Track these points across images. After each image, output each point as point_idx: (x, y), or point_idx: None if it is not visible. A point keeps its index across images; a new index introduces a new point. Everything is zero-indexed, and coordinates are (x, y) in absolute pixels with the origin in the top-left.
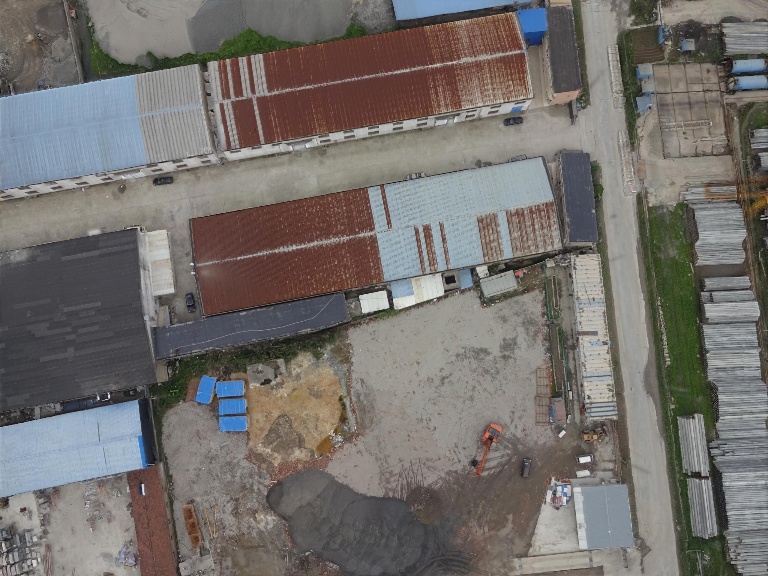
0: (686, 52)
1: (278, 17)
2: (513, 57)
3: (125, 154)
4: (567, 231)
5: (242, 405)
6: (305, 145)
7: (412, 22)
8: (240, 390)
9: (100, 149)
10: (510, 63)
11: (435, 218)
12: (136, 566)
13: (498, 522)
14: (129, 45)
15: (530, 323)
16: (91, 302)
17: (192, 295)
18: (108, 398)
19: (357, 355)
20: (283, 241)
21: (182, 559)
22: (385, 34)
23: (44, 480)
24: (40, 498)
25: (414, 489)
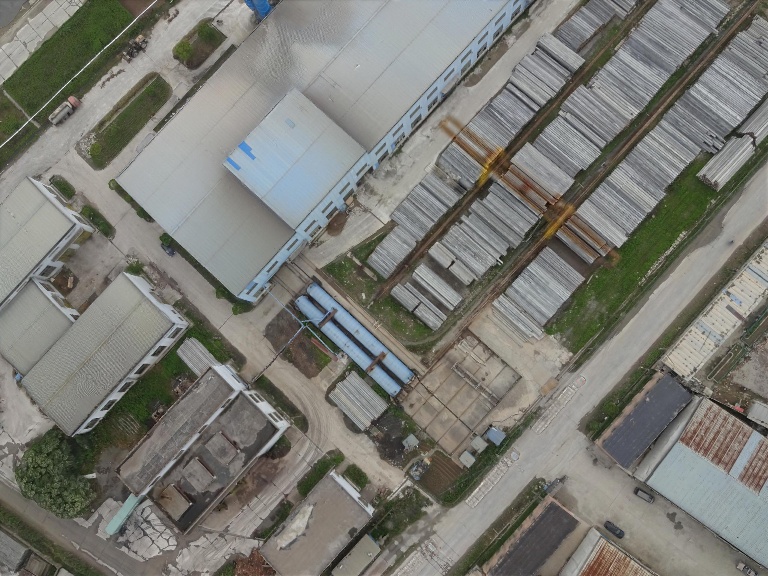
0: None
1: None
2: None
3: None
4: None
5: None
6: None
7: None
8: None
9: None
10: None
11: None
12: None
13: None
14: None
15: (766, 363)
16: None
17: None
18: None
19: None
20: None
21: None
22: None
23: None
24: None
25: None
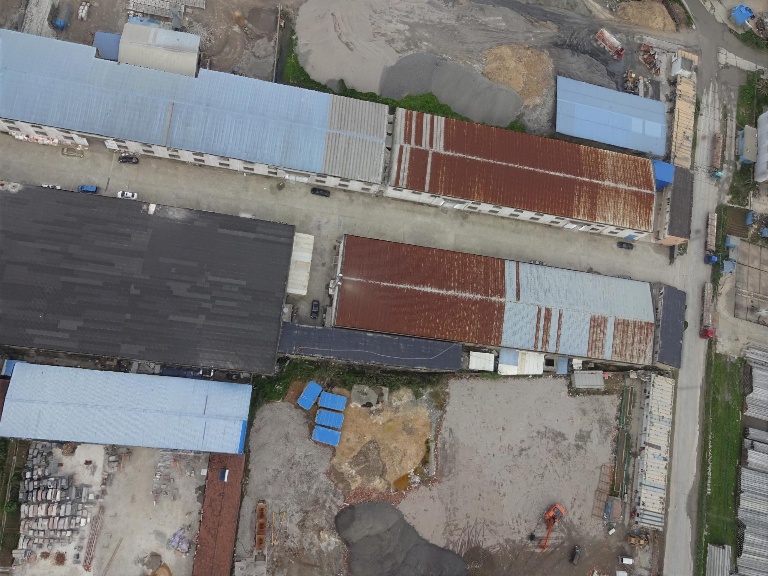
0: (765, 238)
1: (460, 92)
2: (645, 195)
3: (304, 158)
4: (658, 352)
5: (339, 420)
6: (455, 205)
7: (565, 137)
8: (342, 405)
9: (283, 145)
10: (642, 198)
11: (557, 305)
12: (188, 553)
13: None
14: (327, 67)
15: (605, 422)
16: (237, 279)
17: (319, 303)
18: (211, 375)
19: (452, 405)
20: (424, 281)
21: (236, 558)
22: (548, 139)
23: (135, 437)
24: (111, 455)
25: (473, 548)
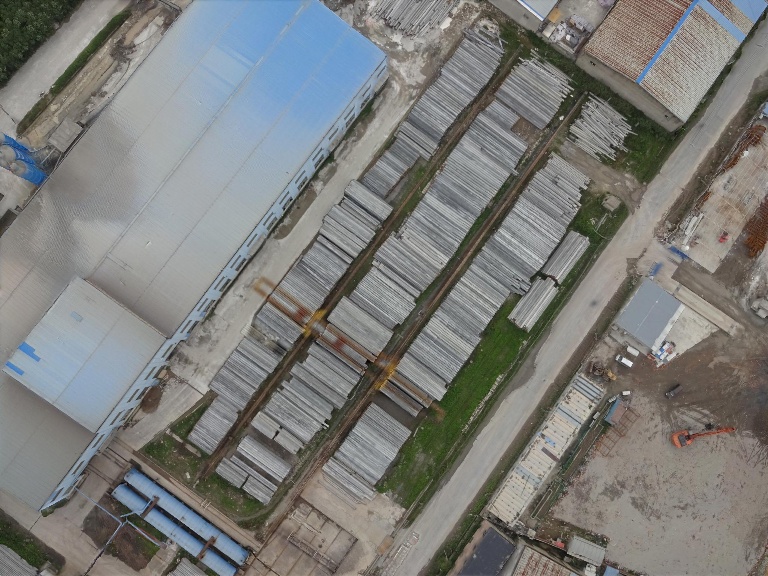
0: None
1: None
2: None
3: None
4: None
5: None
6: None
7: None
8: None
9: None
10: None
11: None
12: None
13: (723, 370)
14: None
15: (582, 496)
16: None
17: None
18: None
19: None
20: None
21: None
22: None
23: None
24: None
25: (767, 445)
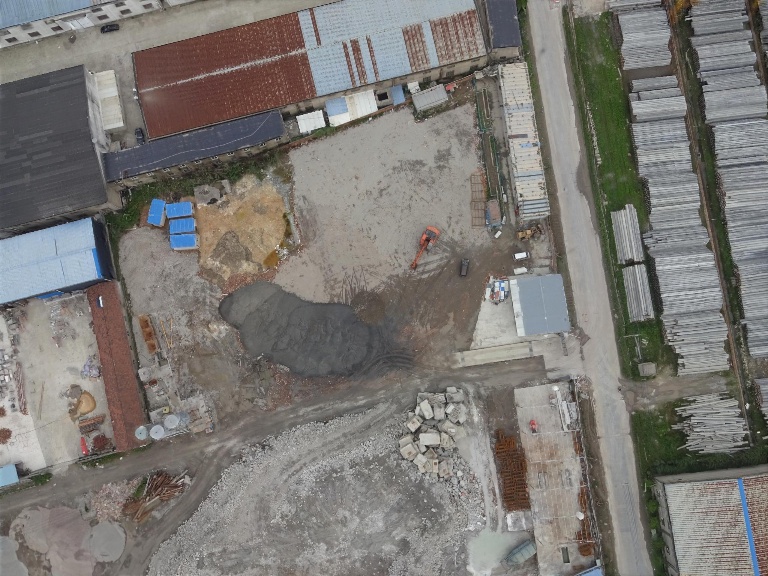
0: None
1: None
2: None
3: None
4: (491, 38)
5: (191, 224)
6: None
7: None
8: (188, 210)
9: None
10: None
11: (362, 33)
12: (100, 377)
13: (440, 320)
14: None
15: (463, 134)
16: (43, 131)
17: (141, 129)
18: None
19: (298, 174)
20: (219, 65)
21: None
22: None
23: (8, 294)
24: (9, 320)
25: (358, 294)
